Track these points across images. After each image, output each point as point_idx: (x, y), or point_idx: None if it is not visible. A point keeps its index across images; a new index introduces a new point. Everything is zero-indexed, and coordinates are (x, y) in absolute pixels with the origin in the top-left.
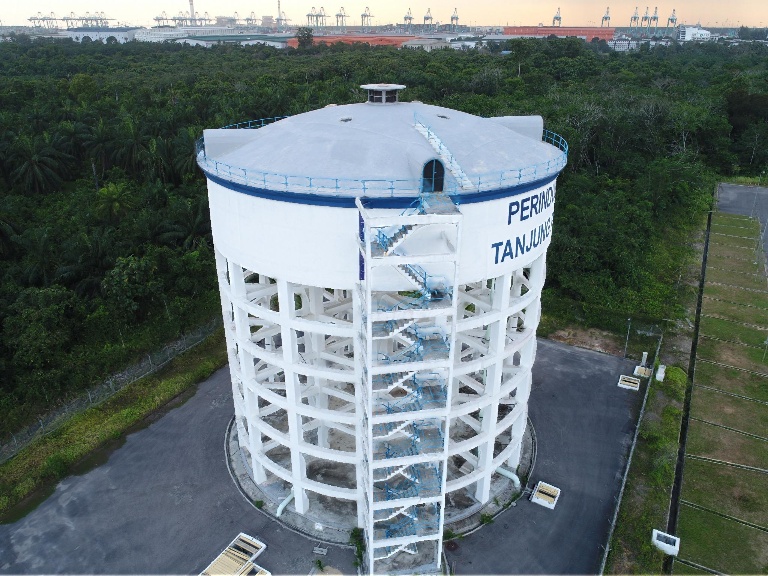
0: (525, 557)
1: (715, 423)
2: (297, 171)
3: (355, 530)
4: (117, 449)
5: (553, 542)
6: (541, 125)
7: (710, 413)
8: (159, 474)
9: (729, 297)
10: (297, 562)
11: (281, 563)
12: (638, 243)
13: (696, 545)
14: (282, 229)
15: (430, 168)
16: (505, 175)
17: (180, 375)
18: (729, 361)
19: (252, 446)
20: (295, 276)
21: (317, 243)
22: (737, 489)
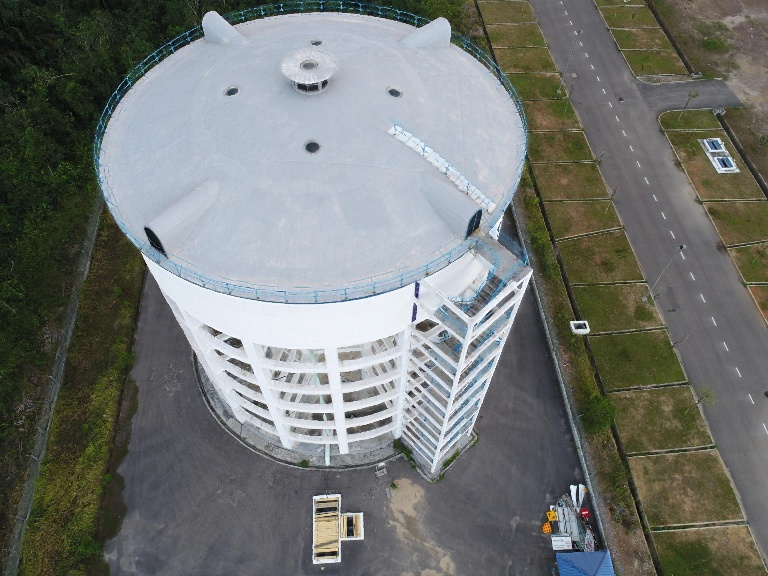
0: (510, 391)
1: (561, 199)
2: (329, 261)
3: (396, 443)
4: (123, 490)
5: (520, 368)
6: (449, 31)
7: (554, 190)
8: (191, 489)
9: (512, 41)
10: (372, 491)
11: (361, 500)
12: (425, 2)
13: (595, 318)
14: (331, 318)
15: (473, 220)
16: (502, 168)
17: (100, 376)
18: (543, 125)
19: (283, 434)
20: (347, 343)
21: (373, 317)
22: (597, 257)
